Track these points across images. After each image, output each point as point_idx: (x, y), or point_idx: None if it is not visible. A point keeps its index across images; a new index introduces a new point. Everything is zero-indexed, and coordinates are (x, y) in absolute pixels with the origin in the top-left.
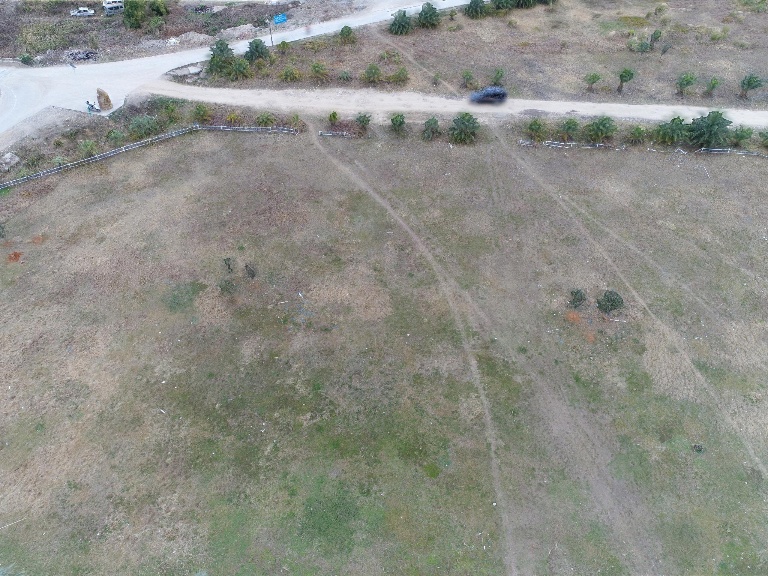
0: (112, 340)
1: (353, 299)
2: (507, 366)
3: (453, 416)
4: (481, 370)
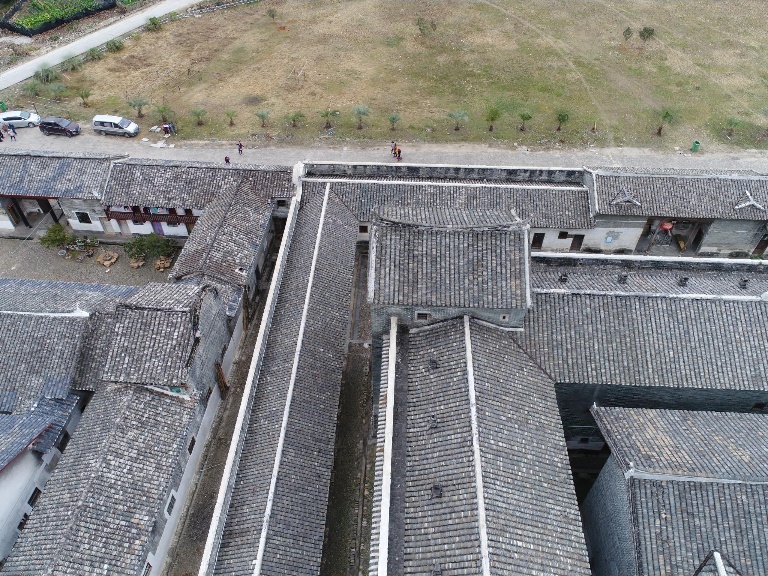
0: (362, 56)
1: (494, 42)
2: (590, 64)
3: (564, 79)
4: (576, 65)
